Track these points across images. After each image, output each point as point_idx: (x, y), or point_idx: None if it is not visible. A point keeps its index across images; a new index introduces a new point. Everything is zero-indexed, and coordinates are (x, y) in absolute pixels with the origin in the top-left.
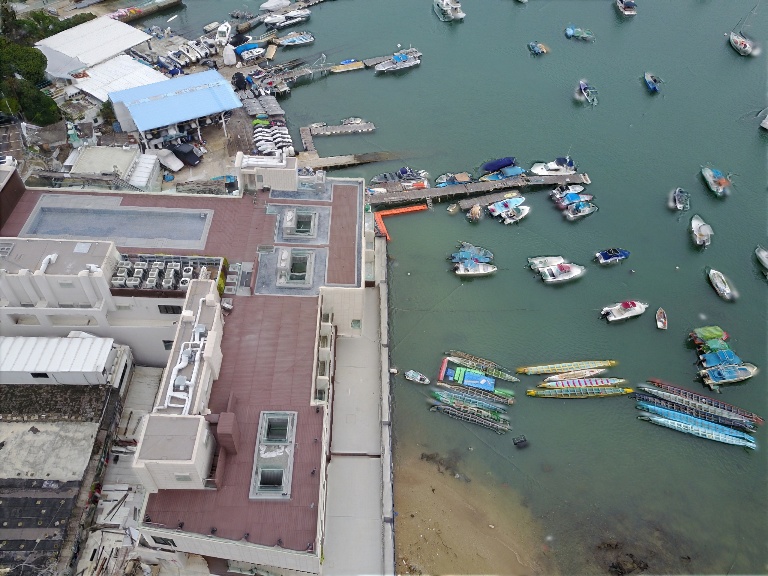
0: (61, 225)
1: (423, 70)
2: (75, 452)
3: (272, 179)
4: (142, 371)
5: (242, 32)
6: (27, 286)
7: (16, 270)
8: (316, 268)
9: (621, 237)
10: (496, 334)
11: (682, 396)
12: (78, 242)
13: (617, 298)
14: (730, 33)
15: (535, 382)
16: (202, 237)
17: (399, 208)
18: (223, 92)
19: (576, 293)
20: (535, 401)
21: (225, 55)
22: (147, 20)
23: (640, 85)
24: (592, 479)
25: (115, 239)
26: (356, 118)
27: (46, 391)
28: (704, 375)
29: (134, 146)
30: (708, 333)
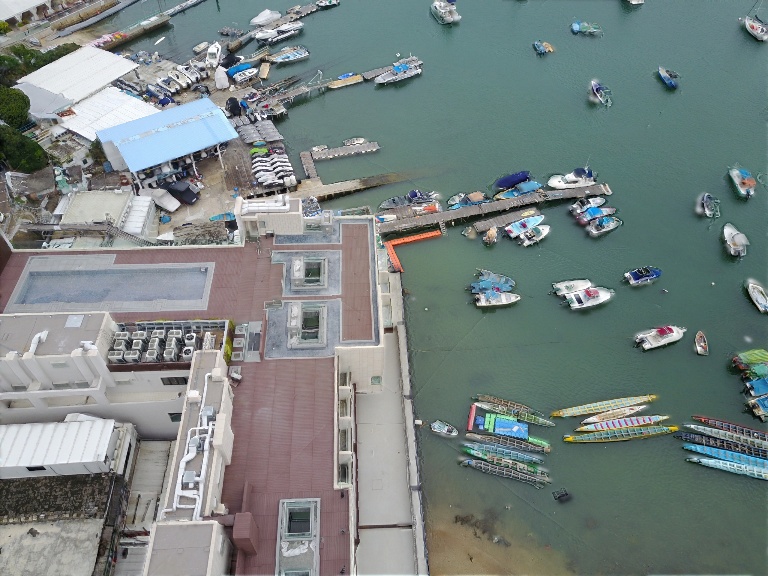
0: (52, 290)
1: (425, 79)
2: (79, 556)
3: (275, 224)
4: (148, 446)
5: (233, 51)
6: (16, 369)
7: (3, 353)
8: (329, 323)
9: (650, 253)
10: (525, 372)
11: (732, 432)
12: (69, 315)
13: (651, 322)
14: (745, 17)
15: (571, 425)
16: (204, 295)
17: (411, 236)
18: (217, 123)
19: (607, 320)
20: (573, 448)
21: (217, 79)
22: (134, 44)
23: (655, 81)
24: (643, 535)
25: (110, 304)
26: (358, 138)
27: (44, 484)
28: (754, 406)
29: (126, 189)
30: (754, 358)
